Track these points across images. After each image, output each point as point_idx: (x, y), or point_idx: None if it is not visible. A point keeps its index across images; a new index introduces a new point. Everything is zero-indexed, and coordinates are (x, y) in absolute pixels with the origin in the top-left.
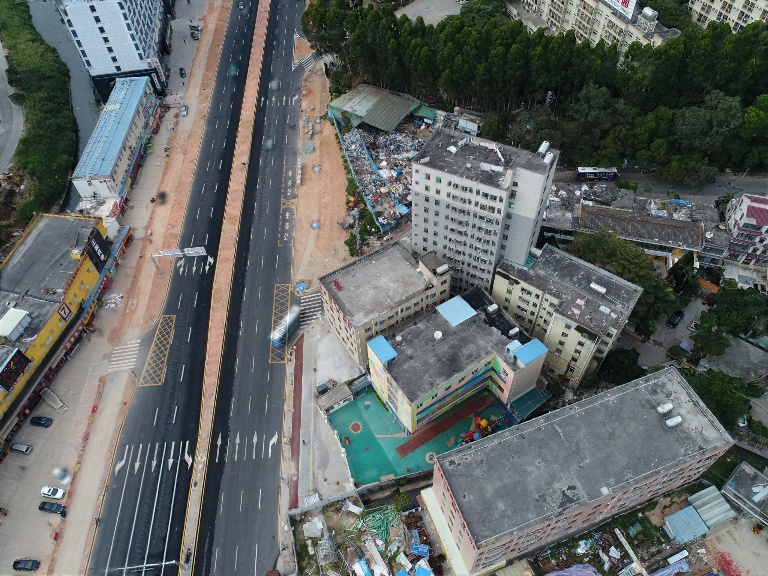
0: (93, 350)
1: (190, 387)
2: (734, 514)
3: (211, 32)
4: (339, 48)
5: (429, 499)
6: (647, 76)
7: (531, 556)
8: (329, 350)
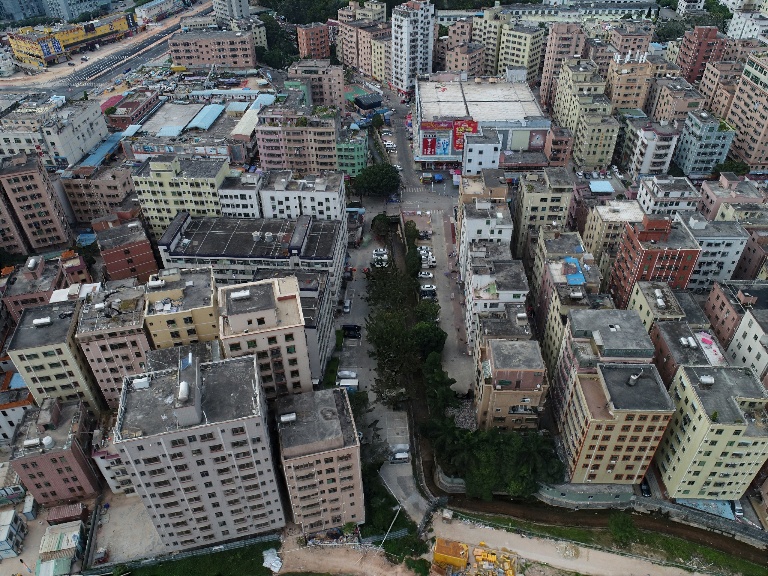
0: (116, 44)
1: (137, 50)
2: (256, 73)
3: None
4: None
5: None
6: None
7: (197, 74)
8: None
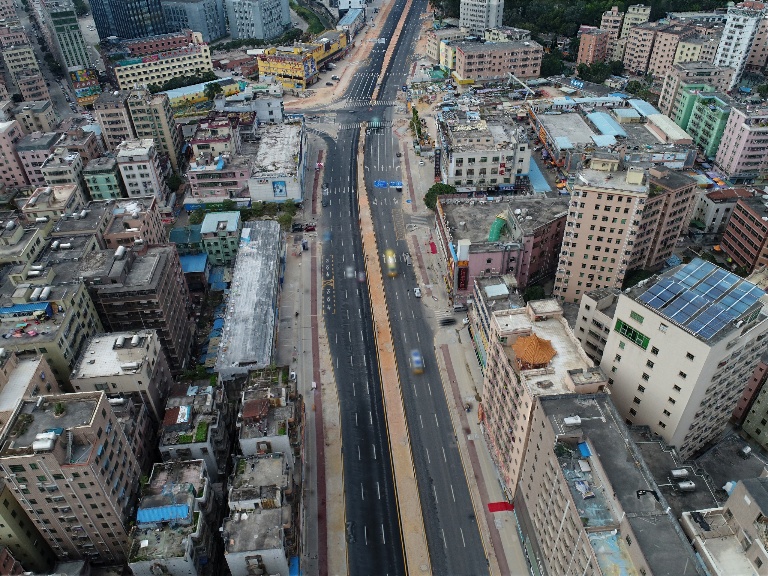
0: (343, 62)
1: None
2: None
3: (384, 10)
4: (441, 5)
5: (454, 72)
6: None
7: None
8: (426, 63)
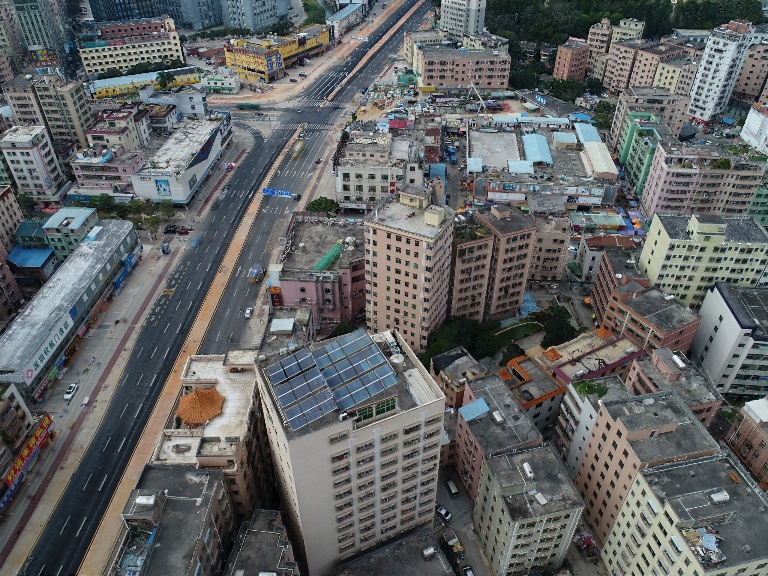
0: (321, 58)
1: None
2: None
3: (392, 7)
4: None
5: None
6: (553, 6)
7: (445, 95)
8: None
